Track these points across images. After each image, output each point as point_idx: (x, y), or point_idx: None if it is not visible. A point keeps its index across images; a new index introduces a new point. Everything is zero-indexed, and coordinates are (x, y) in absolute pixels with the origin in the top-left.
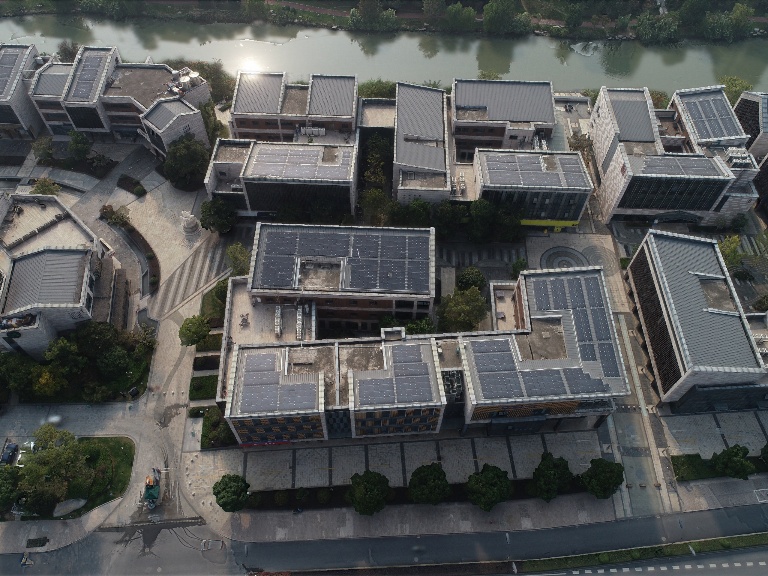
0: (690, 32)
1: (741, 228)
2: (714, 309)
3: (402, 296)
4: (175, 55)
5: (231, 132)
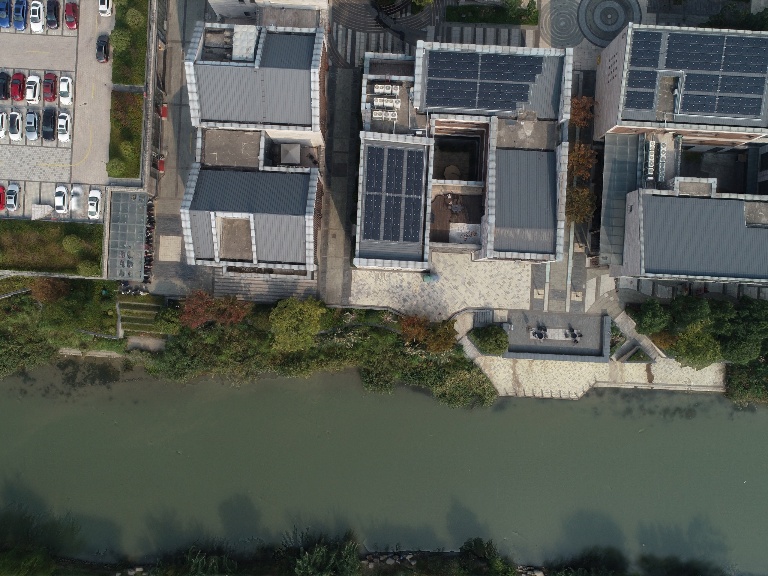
0: (260, 573)
1: (360, 74)
2: None
3: None
4: None
5: None
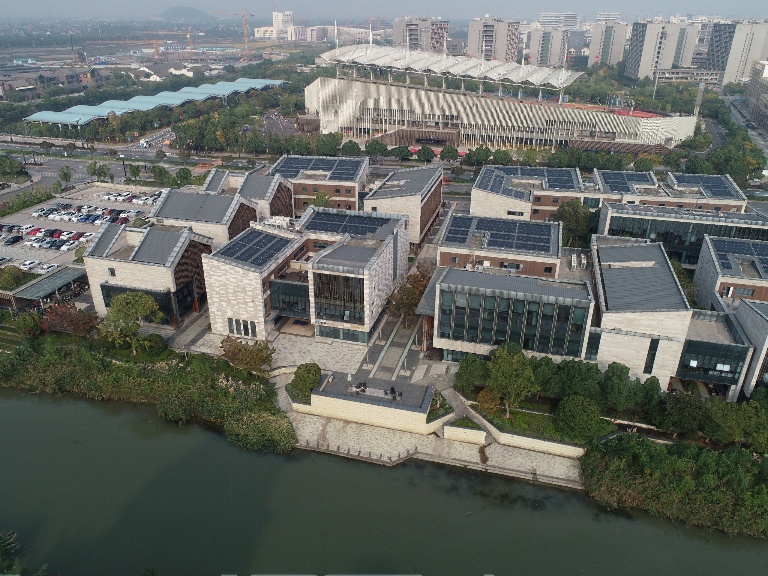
0: None
1: None
2: (403, 181)
3: (628, 204)
4: None
5: None
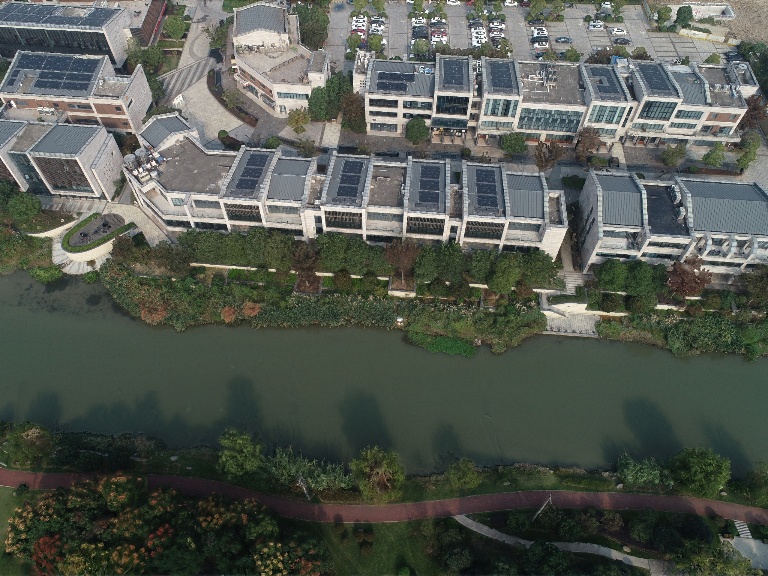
0: None
1: None
2: None
3: (28, 3)
4: (191, 358)
5: (117, 145)
